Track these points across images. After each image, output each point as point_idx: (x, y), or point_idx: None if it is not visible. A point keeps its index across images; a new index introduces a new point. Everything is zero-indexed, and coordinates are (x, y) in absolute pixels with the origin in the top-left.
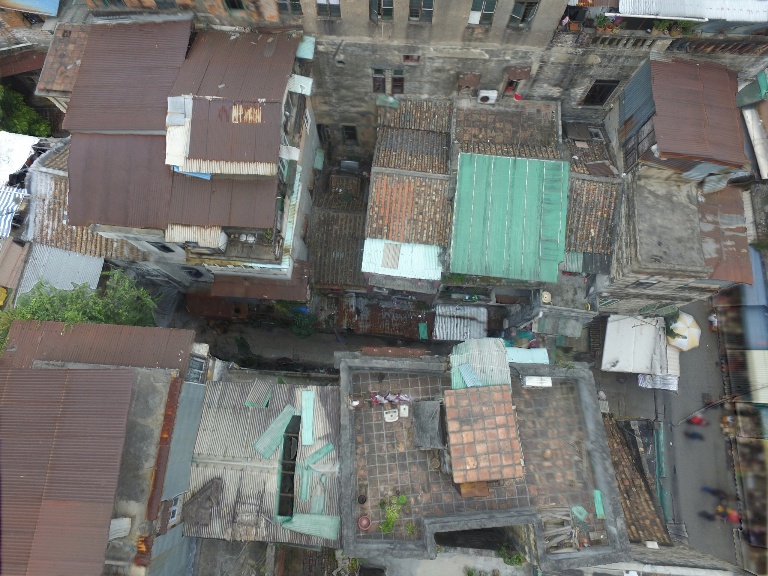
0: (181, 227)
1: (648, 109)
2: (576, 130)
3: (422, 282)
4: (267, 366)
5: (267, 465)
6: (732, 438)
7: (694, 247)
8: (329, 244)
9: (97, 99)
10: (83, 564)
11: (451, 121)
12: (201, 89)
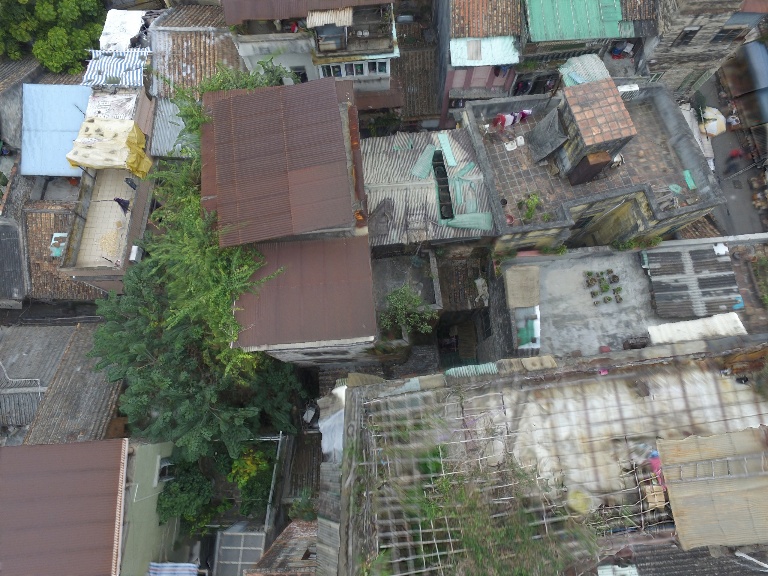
0: (319, 13)
1: None
2: None
3: (495, 88)
4: None
5: (426, 182)
6: (767, 196)
7: None
8: (403, 81)
9: None
10: (336, 200)
11: None
12: None
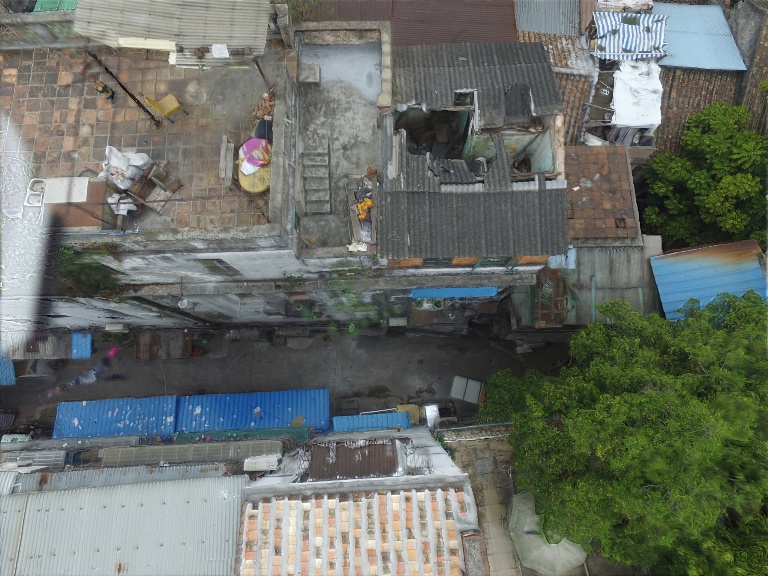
0: None
1: None
2: None
3: None
4: None
5: None
6: None
7: None
8: None
9: None
10: None
11: None
12: None
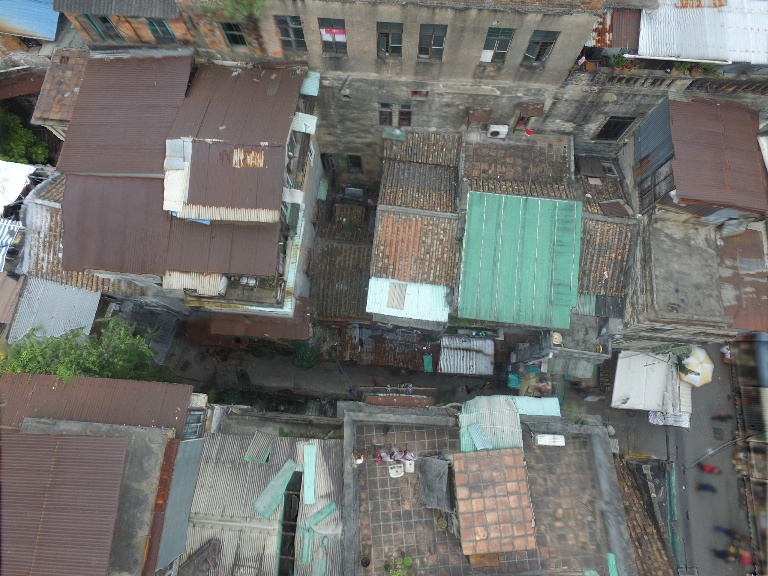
0: (179, 274)
1: (666, 151)
2: (589, 165)
3: None
4: (268, 395)
5: (267, 526)
6: (746, 479)
7: (713, 294)
8: (332, 276)
9: (93, 139)
10: None
11: (460, 155)
12: (201, 131)
